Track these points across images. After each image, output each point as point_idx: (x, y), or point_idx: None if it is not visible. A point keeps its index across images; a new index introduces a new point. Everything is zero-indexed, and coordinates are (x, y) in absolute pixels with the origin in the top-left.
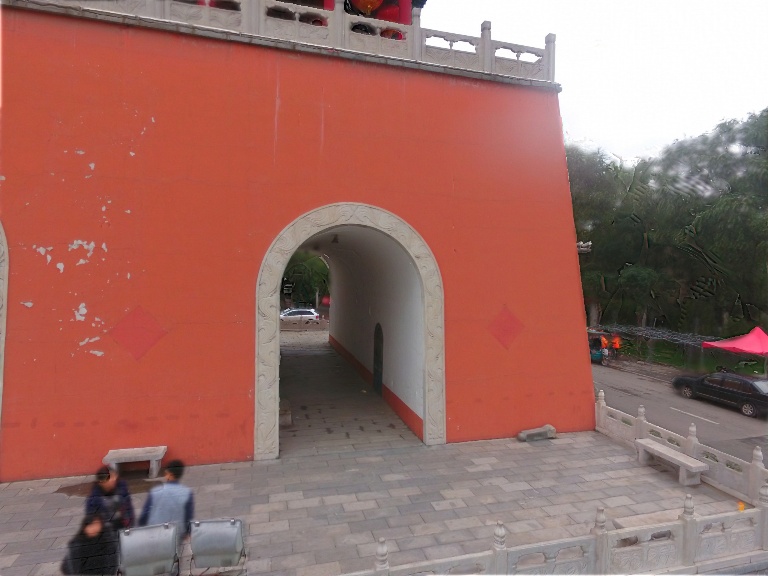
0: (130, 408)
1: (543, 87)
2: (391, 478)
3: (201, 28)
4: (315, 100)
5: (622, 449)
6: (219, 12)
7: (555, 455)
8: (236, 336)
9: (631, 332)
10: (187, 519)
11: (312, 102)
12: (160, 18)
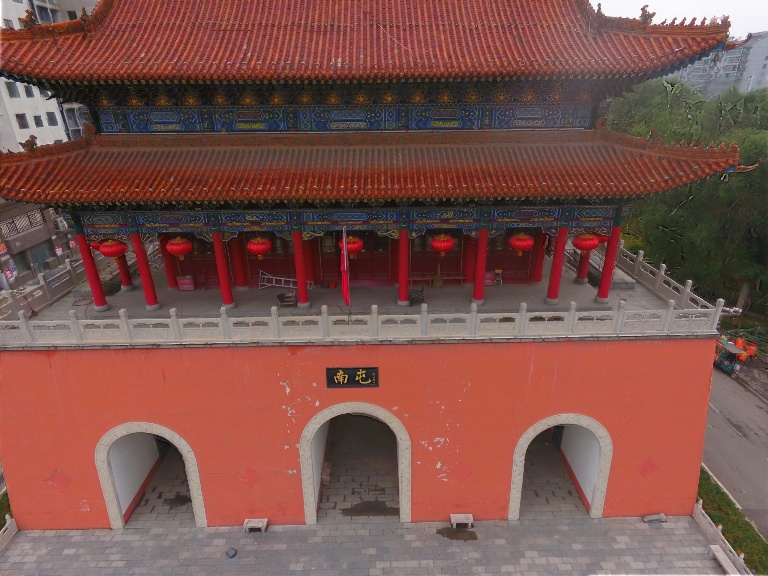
0: (458, 499)
1: (705, 338)
2: (576, 547)
3: (495, 338)
4: (552, 363)
5: (703, 540)
6: (503, 325)
7: (662, 540)
8: (503, 473)
9: (766, 359)
10: (497, 563)
11: (550, 365)
12: (475, 337)
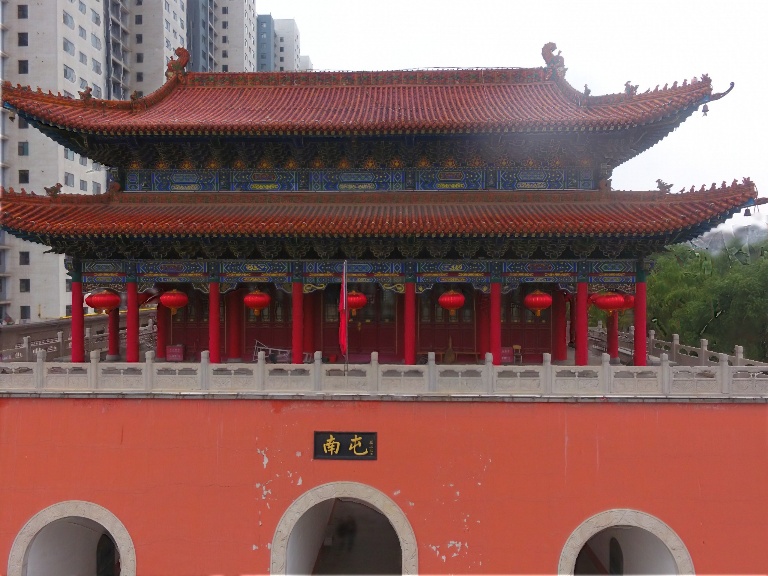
0: None
1: None
2: None
3: (517, 397)
4: (591, 434)
5: None
6: (526, 380)
7: None
8: None
9: None
10: None
11: (589, 436)
12: (493, 394)
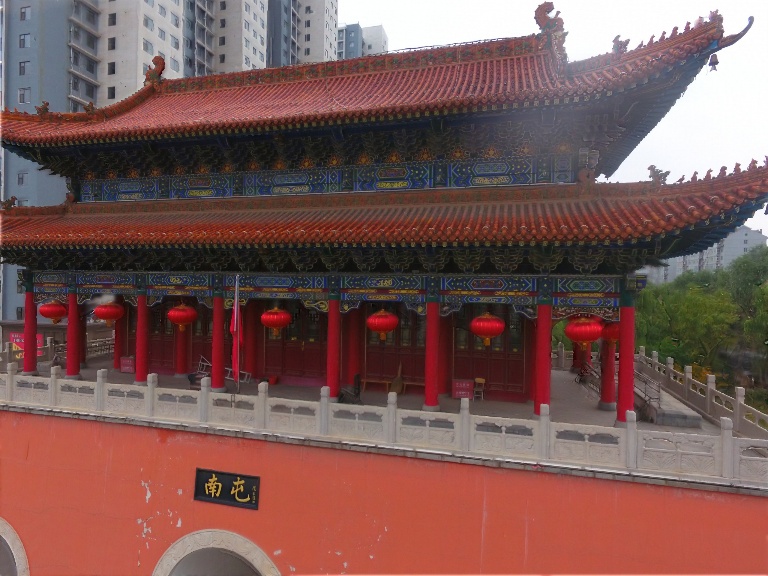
0: None
1: None
2: None
3: (422, 452)
4: (519, 512)
5: None
6: (436, 432)
7: None
8: None
9: None
10: None
11: (516, 514)
12: (392, 445)
